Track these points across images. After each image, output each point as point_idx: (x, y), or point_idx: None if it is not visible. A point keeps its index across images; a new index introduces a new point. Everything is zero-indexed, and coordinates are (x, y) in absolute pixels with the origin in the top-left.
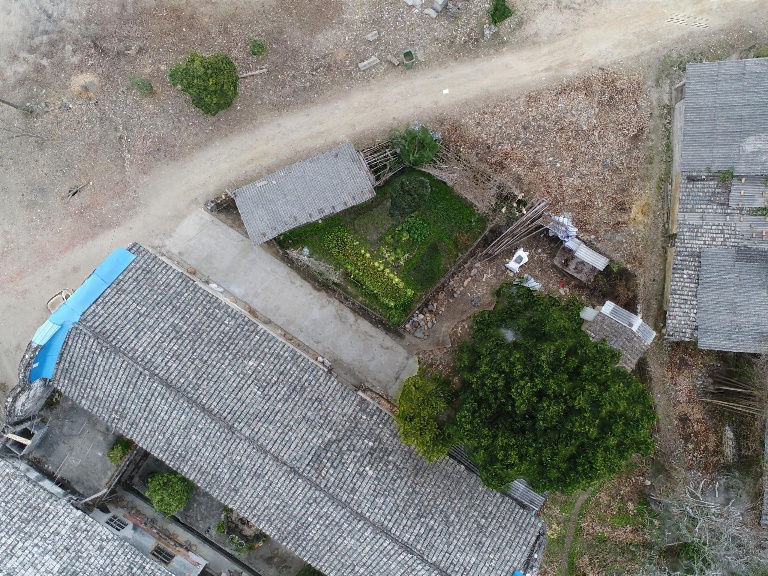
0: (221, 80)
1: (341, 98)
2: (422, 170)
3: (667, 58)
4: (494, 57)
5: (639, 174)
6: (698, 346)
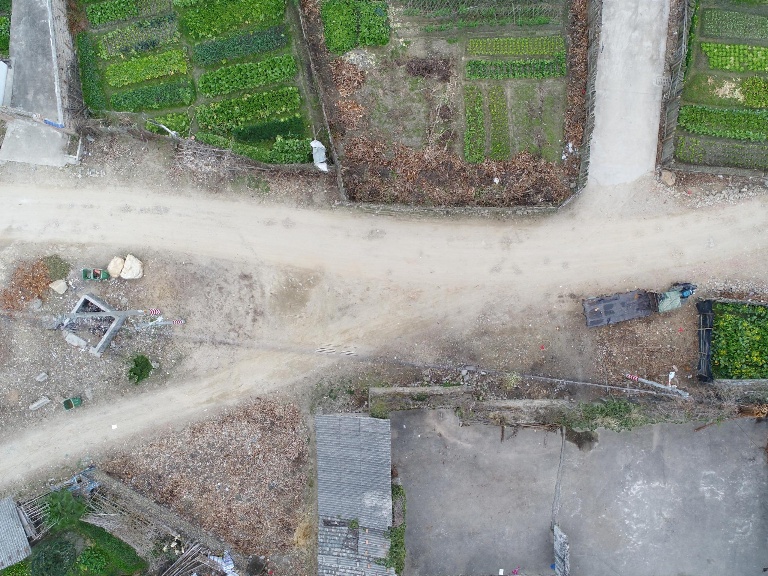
0: None
1: (15, 439)
2: (80, 520)
3: (319, 386)
4: (158, 391)
5: (303, 495)
6: None
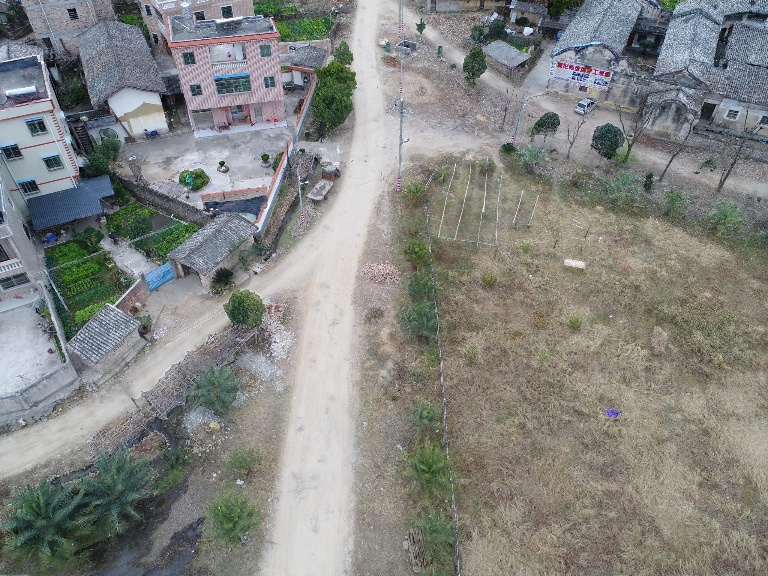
0: None
1: None
2: None
3: None
4: None
5: None
6: None
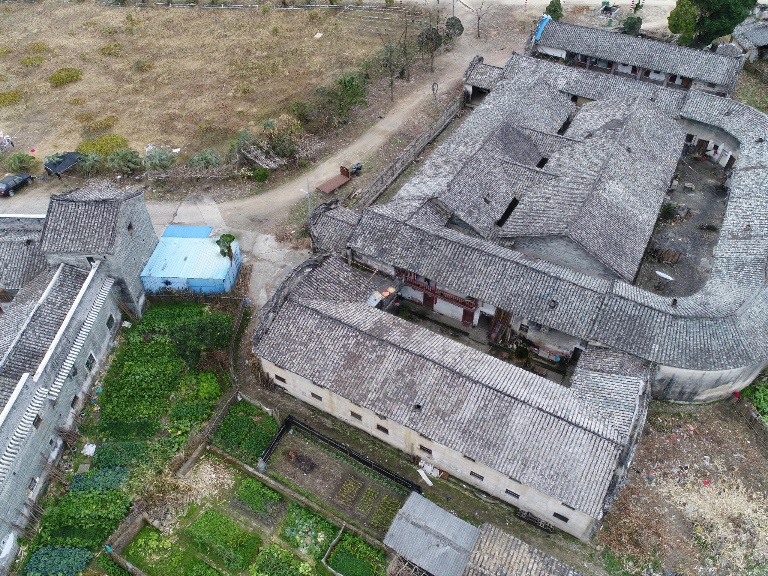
0: (561, 8)
1: None
2: None
3: None
4: None
5: None
6: (759, 46)
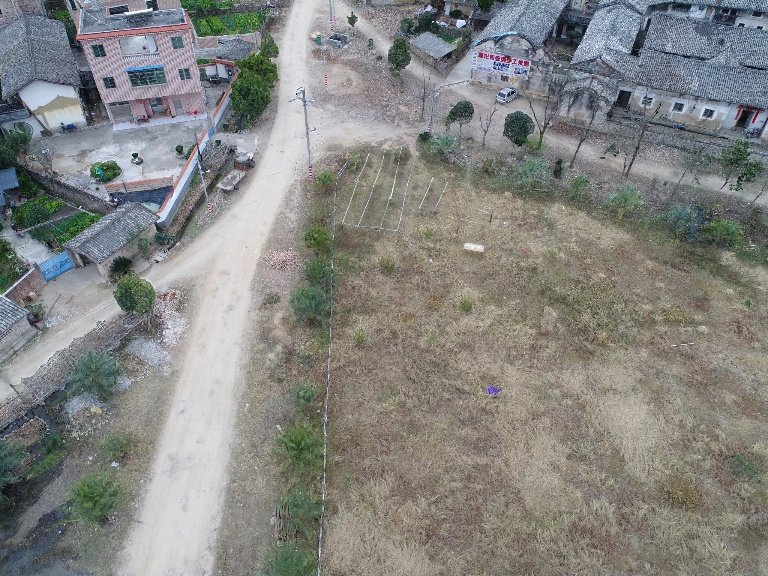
0: None
1: None
2: None
3: (356, 7)
4: None
5: None
6: None
